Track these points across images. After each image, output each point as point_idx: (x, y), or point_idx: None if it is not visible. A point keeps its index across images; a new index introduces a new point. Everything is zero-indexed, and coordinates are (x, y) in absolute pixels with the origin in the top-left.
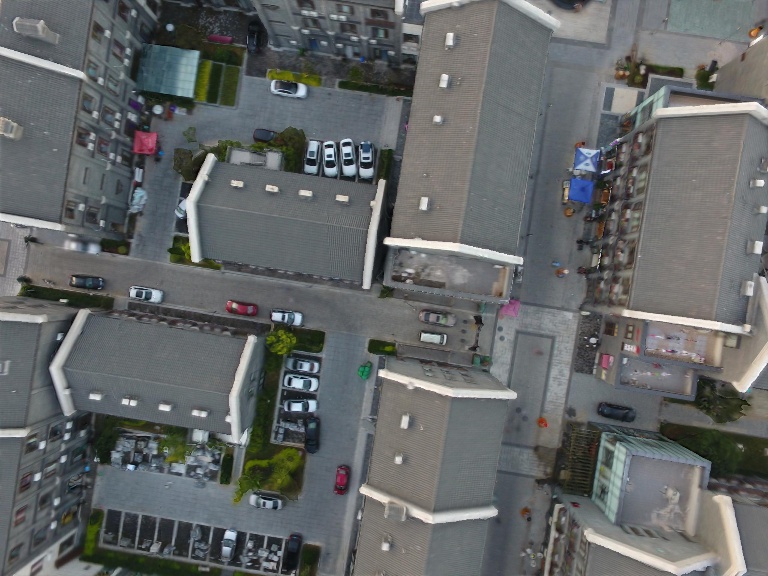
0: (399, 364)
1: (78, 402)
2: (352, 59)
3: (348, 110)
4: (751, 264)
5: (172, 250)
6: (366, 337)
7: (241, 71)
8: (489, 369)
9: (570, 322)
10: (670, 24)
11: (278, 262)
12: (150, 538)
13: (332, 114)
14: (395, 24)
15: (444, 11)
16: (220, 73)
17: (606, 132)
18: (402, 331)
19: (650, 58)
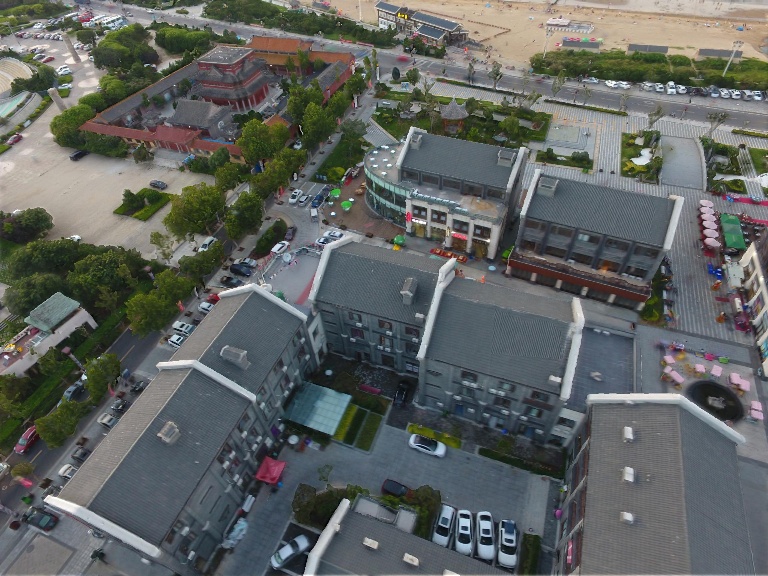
0: None
1: None
2: (494, 429)
3: (487, 479)
4: None
5: None
6: None
7: (383, 420)
8: None
9: None
10: None
11: None
12: None
13: (469, 480)
14: (554, 407)
15: (615, 406)
16: (363, 418)
17: None
18: None
19: None
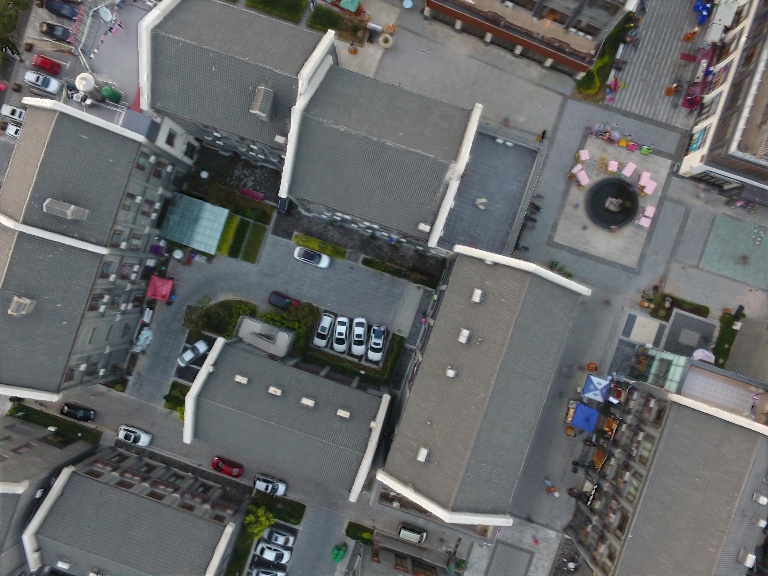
0: (372, 575)
1: (46, 560)
2: (380, 237)
3: (367, 287)
4: (740, 569)
5: (168, 398)
6: (346, 518)
7: (268, 230)
8: (463, 573)
9: (552, 541)
10: (704, 261)
11: (269, 458)
12: None
13: (351, 288)
14: None
15: (477, 260)
16: (246, 229)
17: (621, 358)
18: (383, 518)
19: (678, 291)
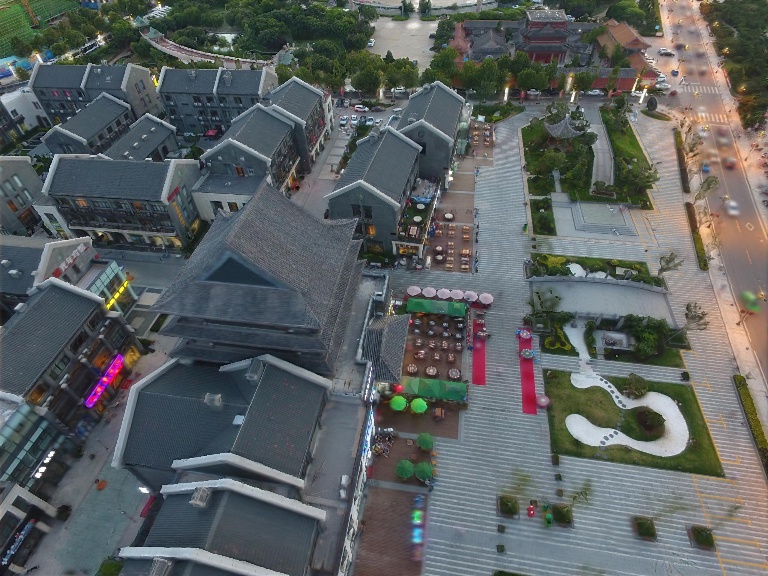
0: None
1: None
2: None
3: None
4: None
5: None
6: None
7: None
8: None
9: None
10: None
11: None
12: (31, 144)
13: None
14: None
15: None
16: None
17: (133, 290)
18: None
19: None
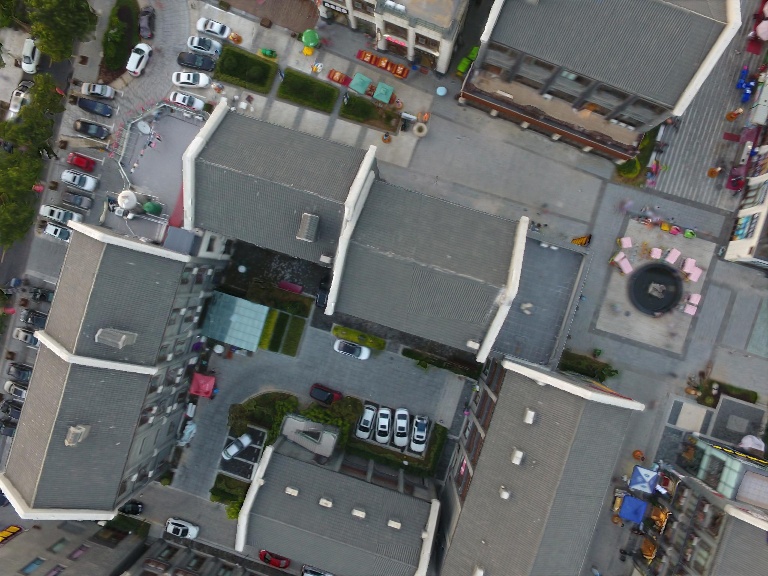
0: None
1: None
2: None
3: (408, 377)
4: None
5: (214, 493)
6: None
7: (307, 322)
8: None
9: None
10: (751, 345)
11: (320, 565)
12: None
13: (391, 379)
14: None
15: (527, 378)
16: (286, 323)
17: (667, 445)
18: None
19: (725, 376)
